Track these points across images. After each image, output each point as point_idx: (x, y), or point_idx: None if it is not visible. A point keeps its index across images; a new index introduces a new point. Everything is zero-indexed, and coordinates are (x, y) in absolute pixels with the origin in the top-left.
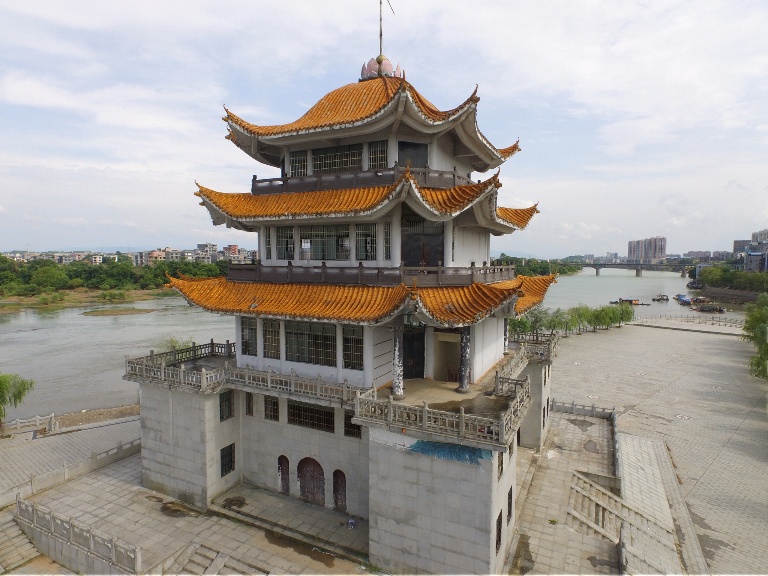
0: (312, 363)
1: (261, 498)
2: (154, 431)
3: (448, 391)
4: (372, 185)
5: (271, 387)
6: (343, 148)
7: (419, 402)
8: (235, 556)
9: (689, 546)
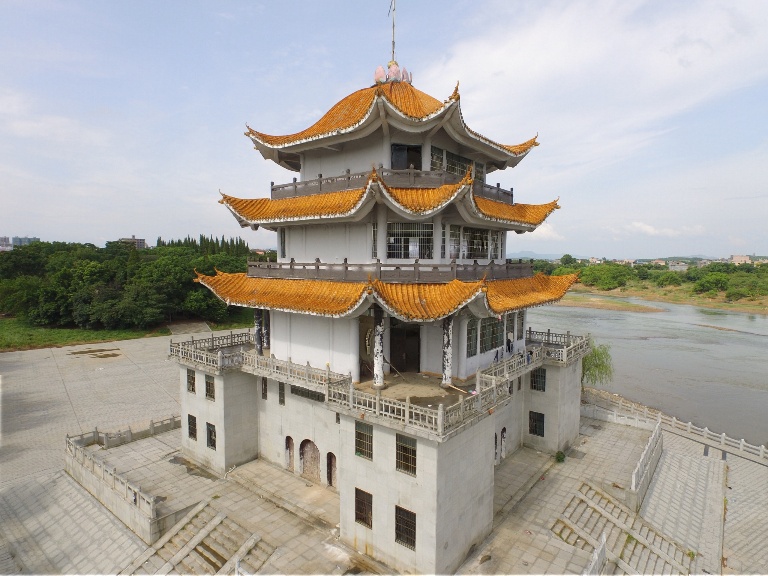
0: None
1: None
2: None
3: None
4: None
5: None
6: None
7: None
8: None
9: None
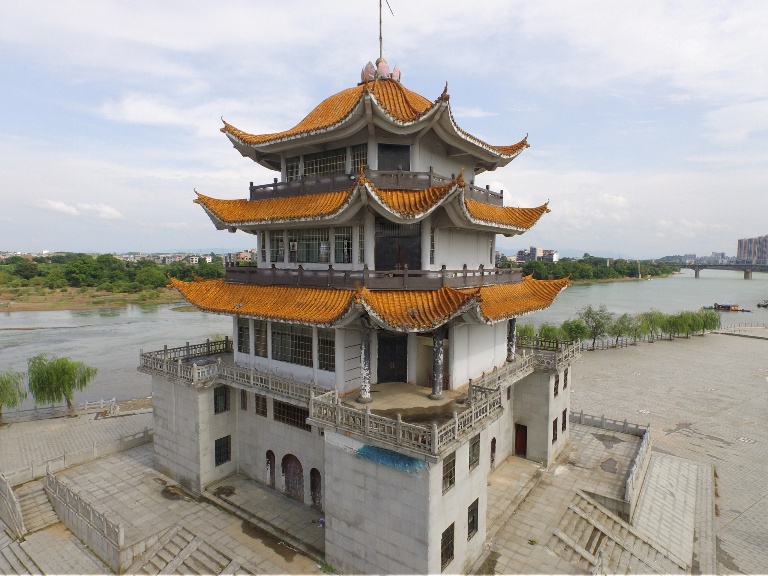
0: (293, 363)
1: (250, 489)
2: (162, 419)
3: (421, 397)
4: (346, 189)
5: (253, 384)
6: (329, 153)
7: (383, 406)
8: (208, 541)
9: None
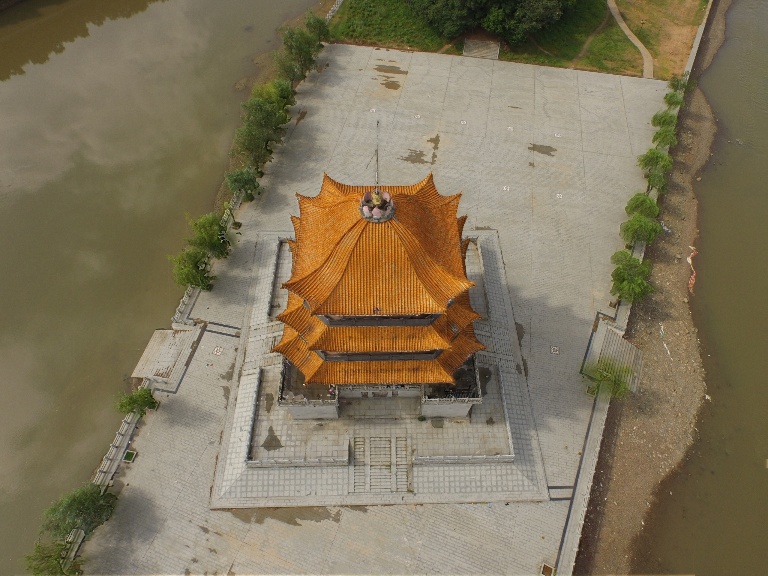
0: None
1: None
2: None
3: None
4: None
5: None
6: None
7: None
8: None
9: (239, 366)
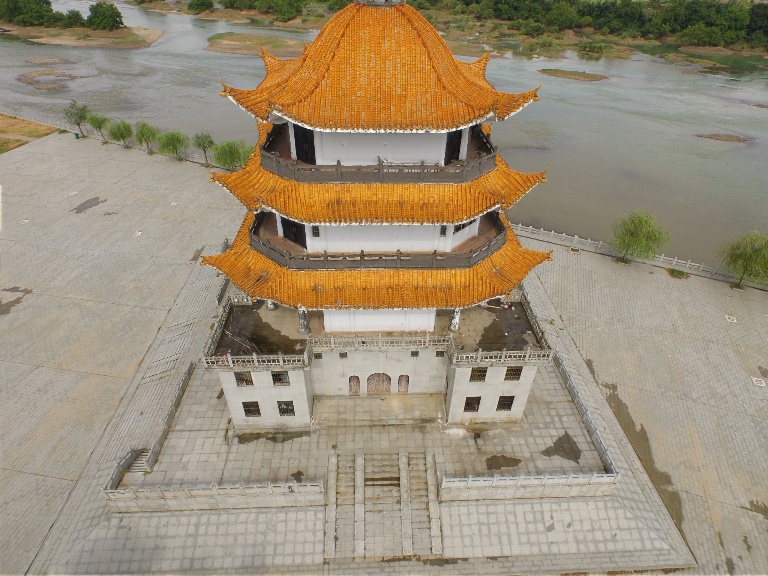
0: None
1: None
2: None
3: None
4: None
5: None
6: None
7: (268, 318)
8: None
9: (422, 568)
